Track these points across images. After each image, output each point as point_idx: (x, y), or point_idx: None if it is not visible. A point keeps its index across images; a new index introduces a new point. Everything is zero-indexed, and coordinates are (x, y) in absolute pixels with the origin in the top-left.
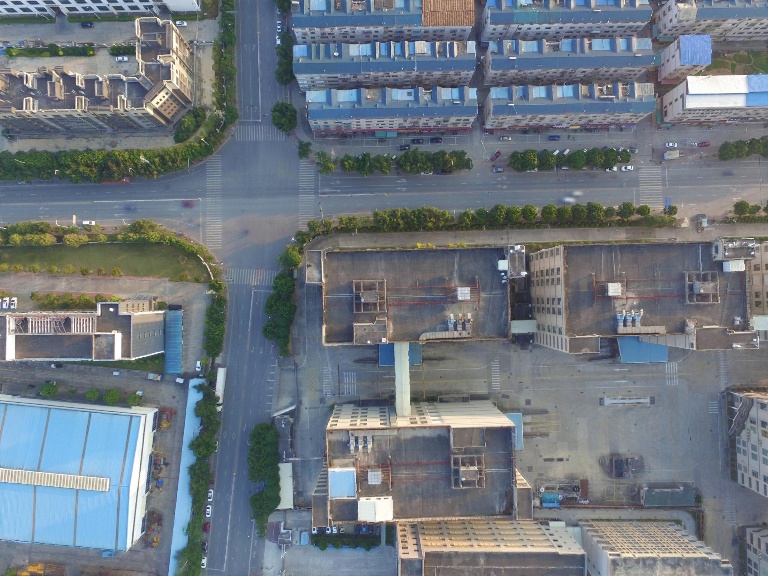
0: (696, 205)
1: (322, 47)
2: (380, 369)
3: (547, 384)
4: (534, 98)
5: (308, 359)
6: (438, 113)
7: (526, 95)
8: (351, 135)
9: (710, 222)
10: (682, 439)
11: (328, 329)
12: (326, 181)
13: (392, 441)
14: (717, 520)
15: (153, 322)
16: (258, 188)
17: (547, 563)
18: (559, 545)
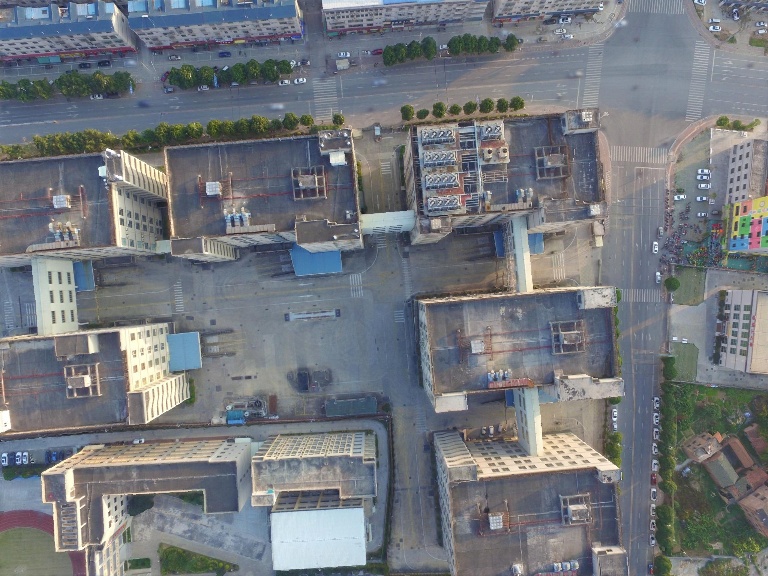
0: (372, 114)
1: None
2: None
3: (231, 303)
4: (172, 9)
5: None
6: (73, 30)
7: (163, 6)
8: (16, 63)
9: (388, 131)
10: (369, 350)
11: None
12: None
13: (7, 356)
14: (408, 427)
15: None
16: None
17: (200, 472)
18: (219, 456)
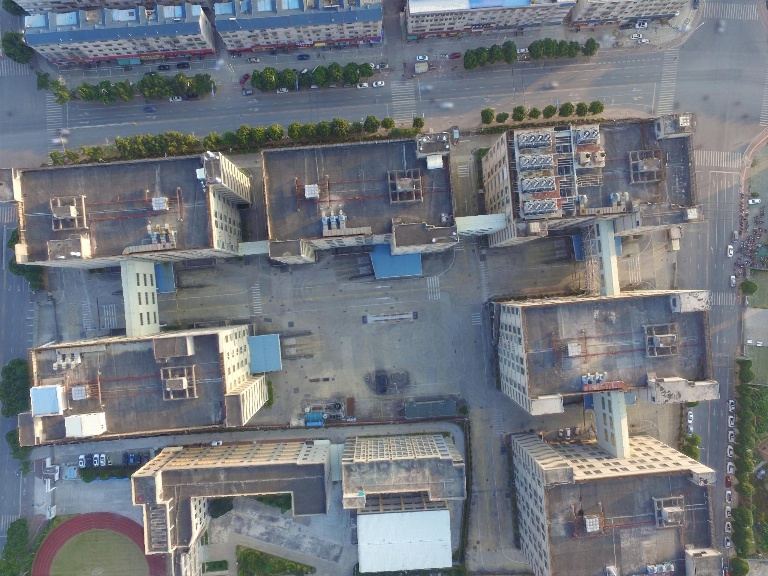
0: (450, 118)
1: None
2: None
3: (309, 305)
4: (259, 12)
5: (66, 294)
6: (160, 32)
7: (250, 9)
8: (95, 65)
9: (465, 134)
10: (447, 352)
11: (30, 249)
12: (74, 113)
13: (102, 358)
14: (485, 430)
15: None
16: (4, 124)
17: (287, 475)
18: (305, 458)
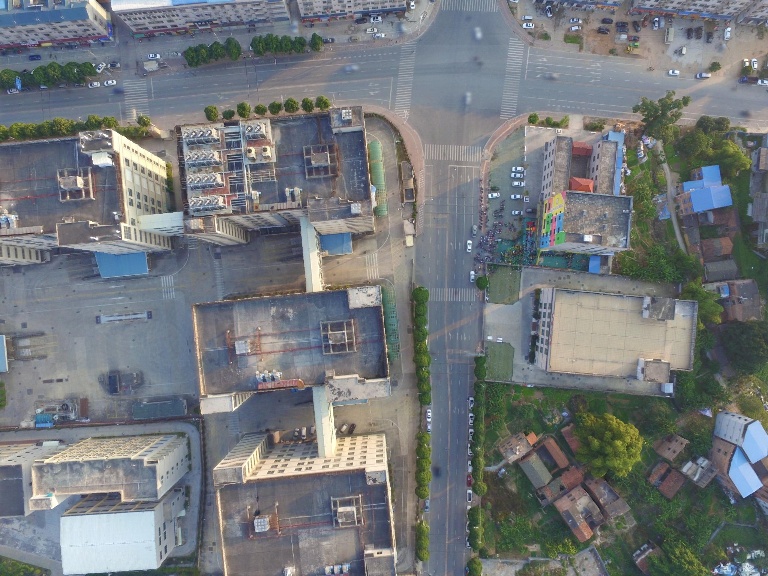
0: (183, 116)
1: None
2: None
3: (42, 306)
4: None
5: None
6: None
7: None
8: None
9: None
10: (181, 351)
11: None
12: None
13: None
14: (220, 430)
15: None
16: None
17: None
18: (11, 459)
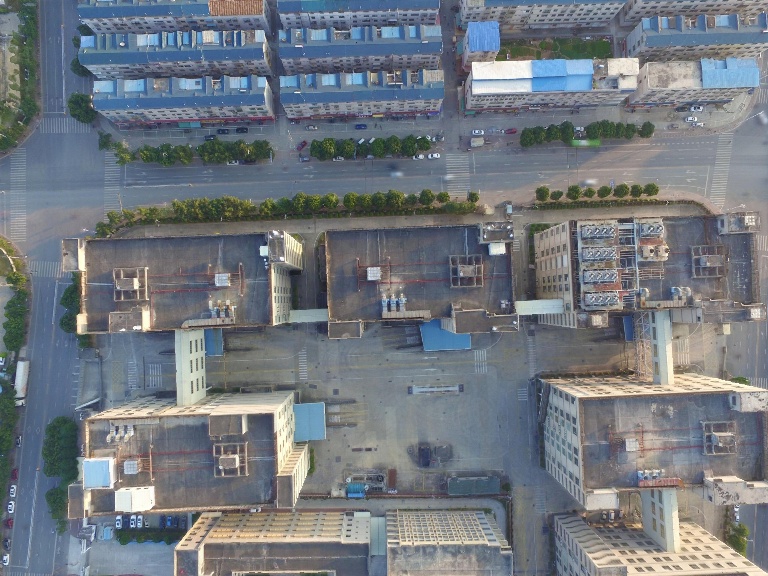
0: (504, 192)
1: (108, 37)
2: None
3: (355, 373)
4: (323, 86)
5: (113, 351)
6: (225, 102)
7: (314, 83)
8: (156, 126)
9: (518, 209)
10: (491, 427)
11: (90, 318)
12: (132, 172)
13: (155, 430)
14: (527, 508)
15: None
16: (63, 180)
17: (331, 553)
18: (348, 535)
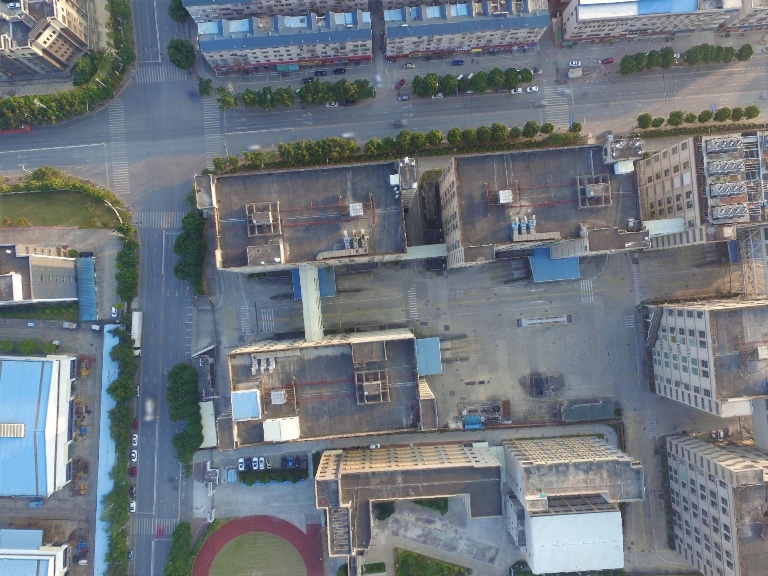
0: (603, 122)
1: None
2: (297, 304)
3: (464, 309)
4: (428, 18)
5: (224, 299)
6: (332, 38)
7: (420, 16)
8: (253, 71)
9: None
10: (600, 355)
11: (224, 255)
12: (231, 119)
13: (295, 362)
14: (638, 432)
15: (60, 267)
16: (163, 130)
17: (464, 477)
18: (477, 460)
